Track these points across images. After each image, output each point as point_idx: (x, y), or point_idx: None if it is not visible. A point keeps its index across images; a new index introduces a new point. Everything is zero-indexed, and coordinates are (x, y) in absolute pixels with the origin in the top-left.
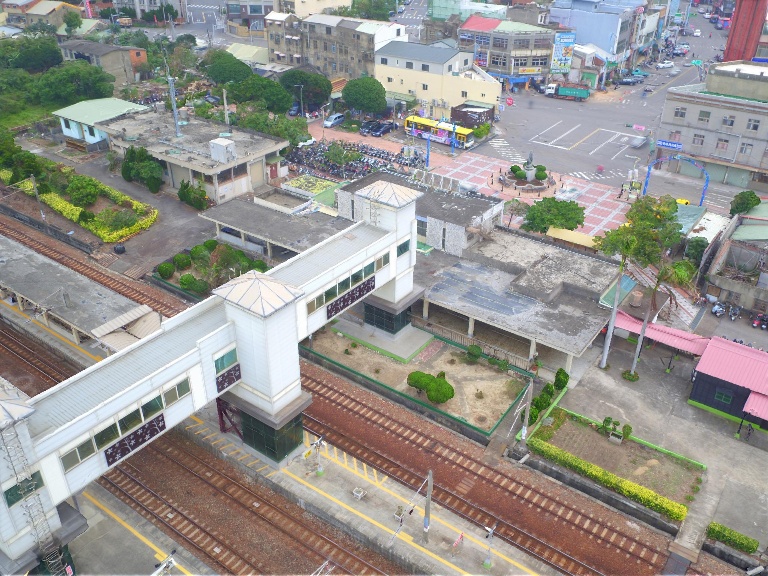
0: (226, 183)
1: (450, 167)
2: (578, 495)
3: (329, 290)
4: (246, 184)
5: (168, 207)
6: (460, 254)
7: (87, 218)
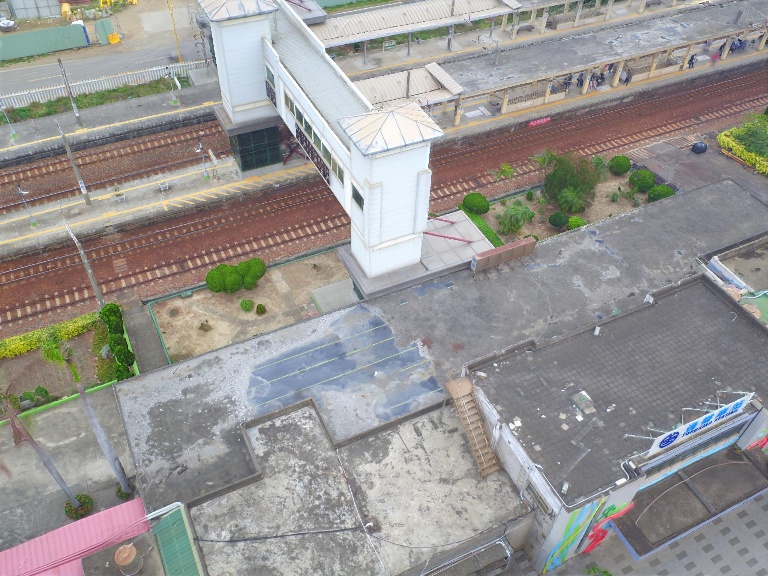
0: None
1: None
2: (25, 332)
3: None
4: None
5: None
6: None
7: None
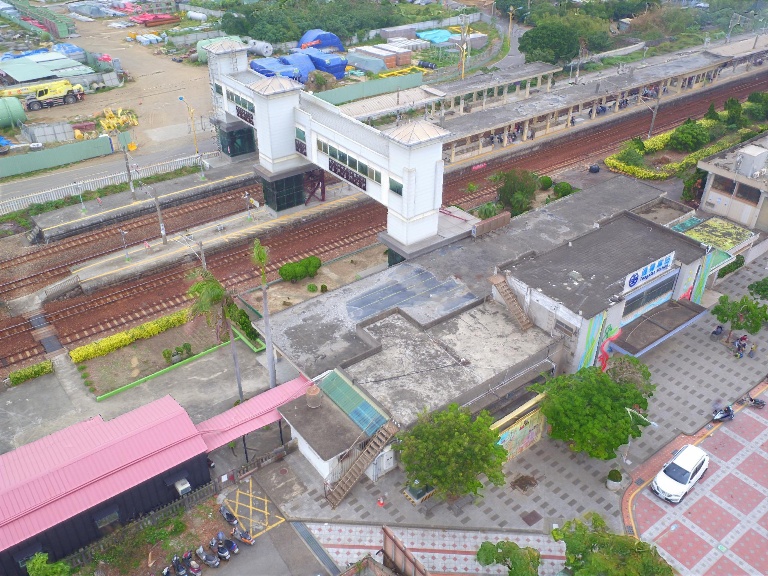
0: (723, 194)
1: None
2: None
3: (334, 149)
4: (750, 215)
5: None
6: None
7: None
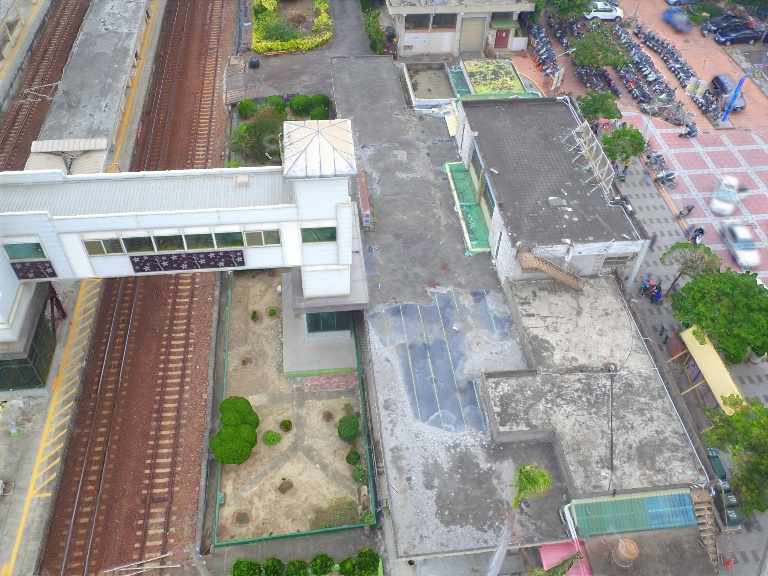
0: (418, 31)
1: (762, 137)
2: None
3: None
4: (451, 42)
5: (354, 35)
6: (503, 282)
7: (258, 14)
